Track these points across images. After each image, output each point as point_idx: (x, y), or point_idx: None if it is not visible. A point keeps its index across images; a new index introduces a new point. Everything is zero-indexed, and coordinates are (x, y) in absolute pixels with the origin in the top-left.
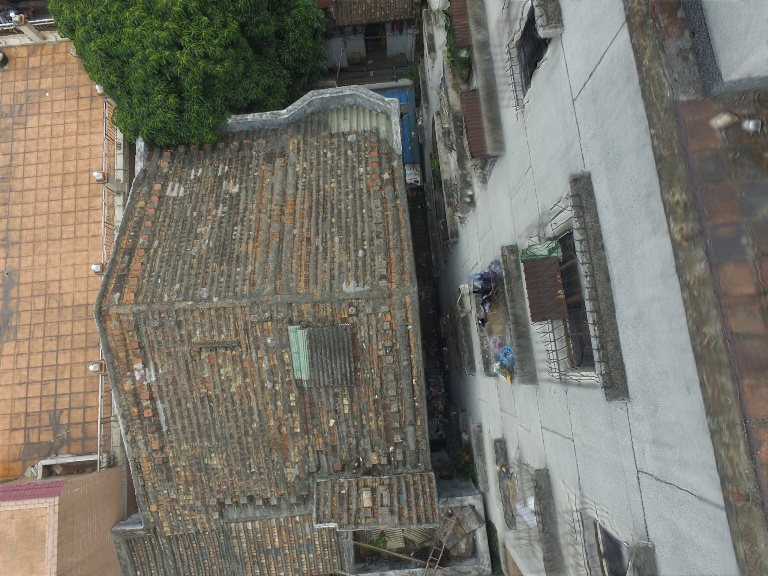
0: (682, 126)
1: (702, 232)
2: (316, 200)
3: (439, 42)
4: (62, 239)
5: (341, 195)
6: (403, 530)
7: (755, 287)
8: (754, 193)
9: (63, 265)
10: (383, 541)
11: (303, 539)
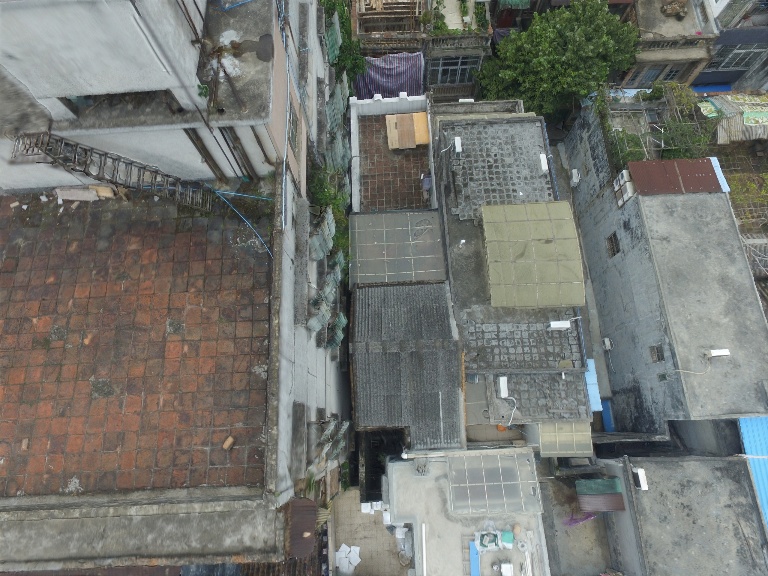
0: None
1: None
2: None
3: None
4: None
5: None
6: None
7: None
8: (13, 233)
9: None
10: None
11: None
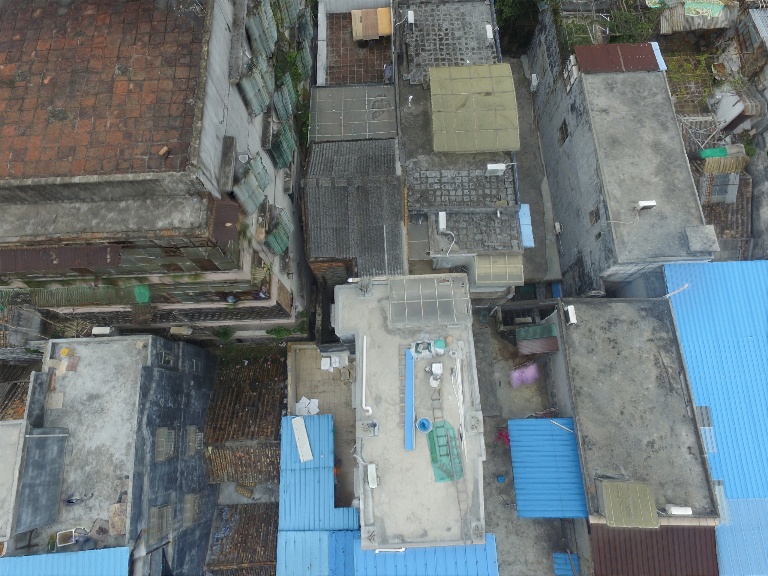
0: None
1: None
2: None
3: None
4: None
5: None
6: (77, 325)
7: None
8: None
9: None
10: (62, 332)
11: (2, 320)
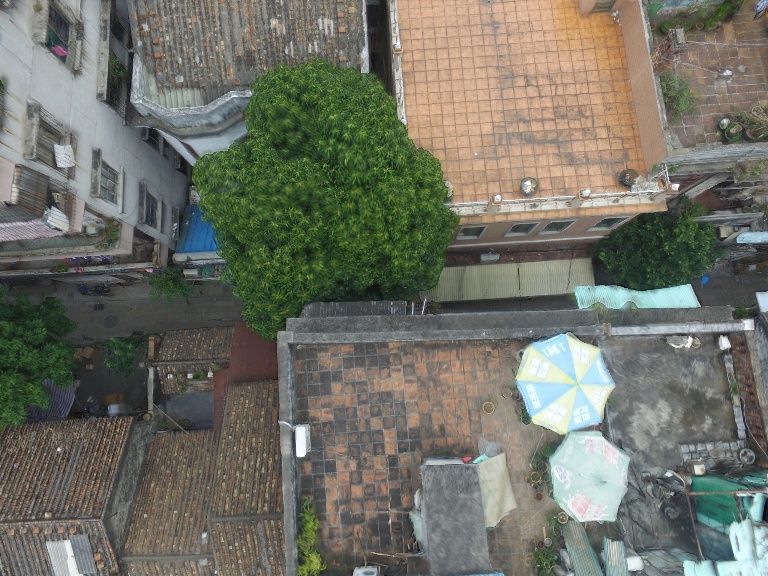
0: None
1: None
2: (200, 2)
3: (77, 131)
4: (445, 27)
5: (181, 8)
6: None
7: None
8: None
9: (442, 7)
10: None
11: None
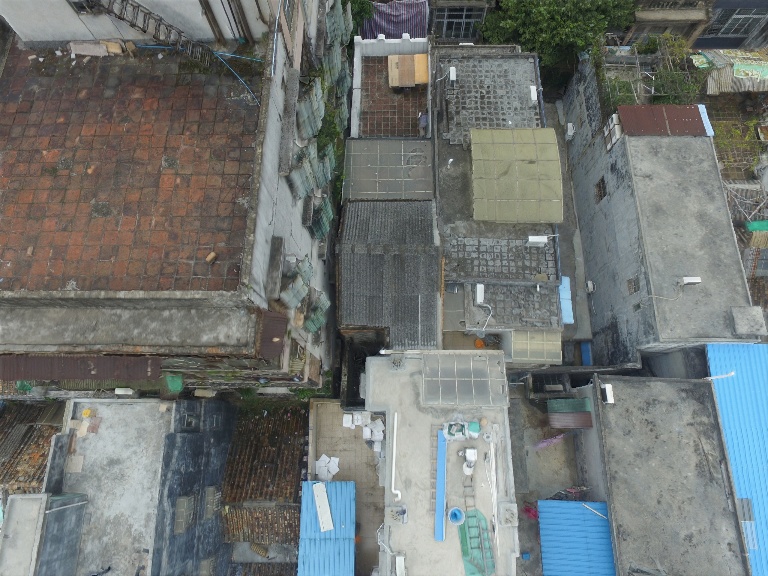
0: (18, 58)
1: (6, 92)
2: None
3: None
4: None
5: None
6: None
7: (14, 110)
8: (30, 81)
9: None
10: None
11: None
